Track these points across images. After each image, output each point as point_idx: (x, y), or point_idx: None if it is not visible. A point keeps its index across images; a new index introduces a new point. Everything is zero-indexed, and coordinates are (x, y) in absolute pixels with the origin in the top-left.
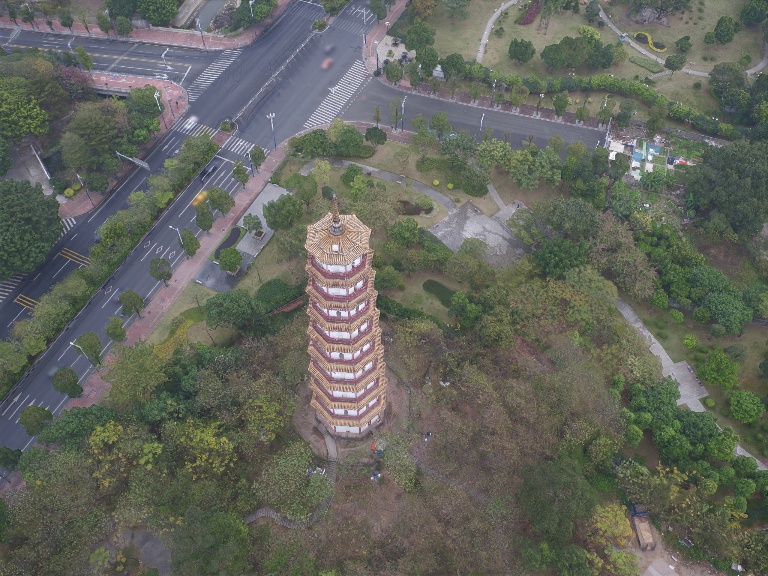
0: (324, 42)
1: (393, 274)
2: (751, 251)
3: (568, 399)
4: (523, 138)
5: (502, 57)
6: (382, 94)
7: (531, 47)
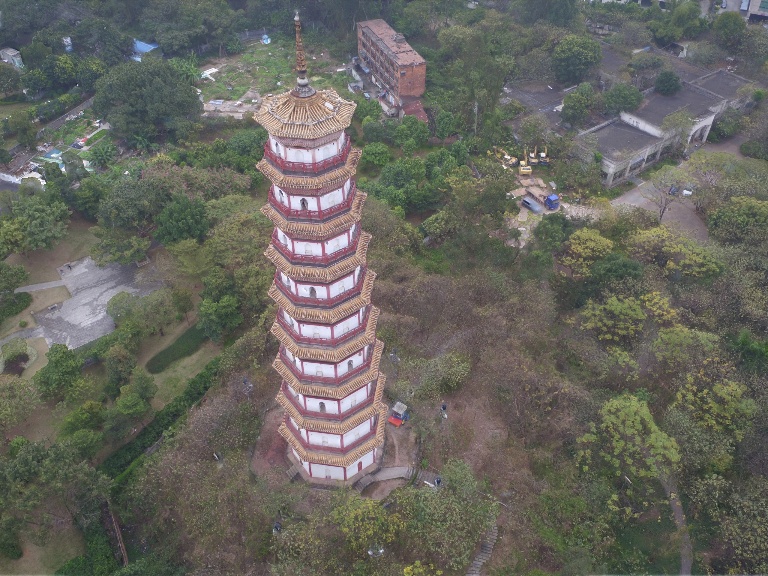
0: None
1: (142, 376)
2: (217, 123)
3: (378, 221)
4: None
5: None
6: None
7: None
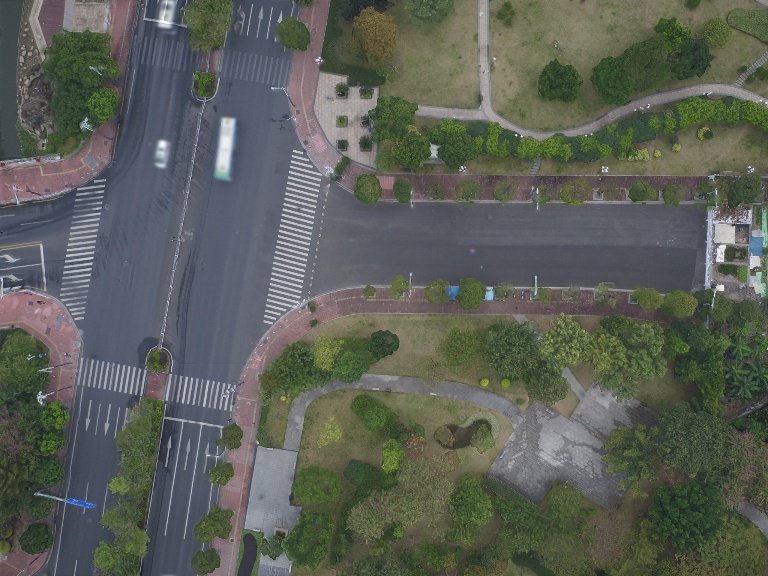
0: (226, 122)
1: None
2: None
3: None
4: (587, 253)
5: (522, 78)
6: (356, 218)
7: (577, 82)
